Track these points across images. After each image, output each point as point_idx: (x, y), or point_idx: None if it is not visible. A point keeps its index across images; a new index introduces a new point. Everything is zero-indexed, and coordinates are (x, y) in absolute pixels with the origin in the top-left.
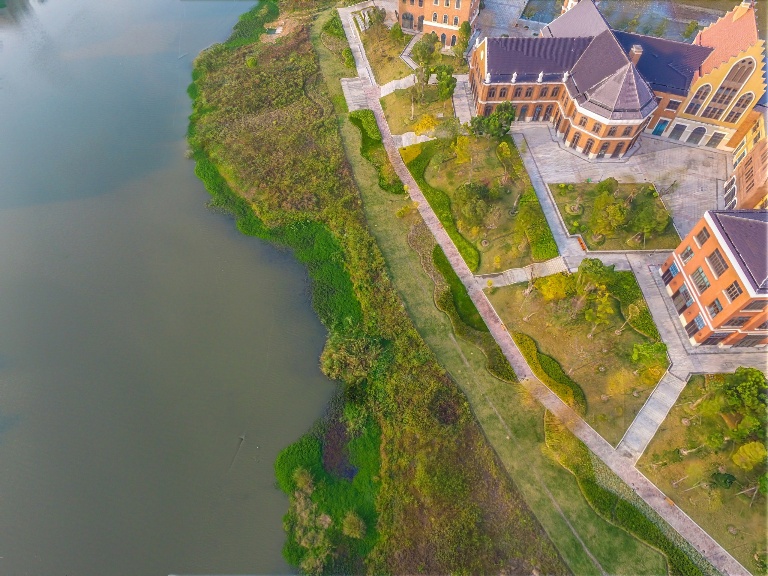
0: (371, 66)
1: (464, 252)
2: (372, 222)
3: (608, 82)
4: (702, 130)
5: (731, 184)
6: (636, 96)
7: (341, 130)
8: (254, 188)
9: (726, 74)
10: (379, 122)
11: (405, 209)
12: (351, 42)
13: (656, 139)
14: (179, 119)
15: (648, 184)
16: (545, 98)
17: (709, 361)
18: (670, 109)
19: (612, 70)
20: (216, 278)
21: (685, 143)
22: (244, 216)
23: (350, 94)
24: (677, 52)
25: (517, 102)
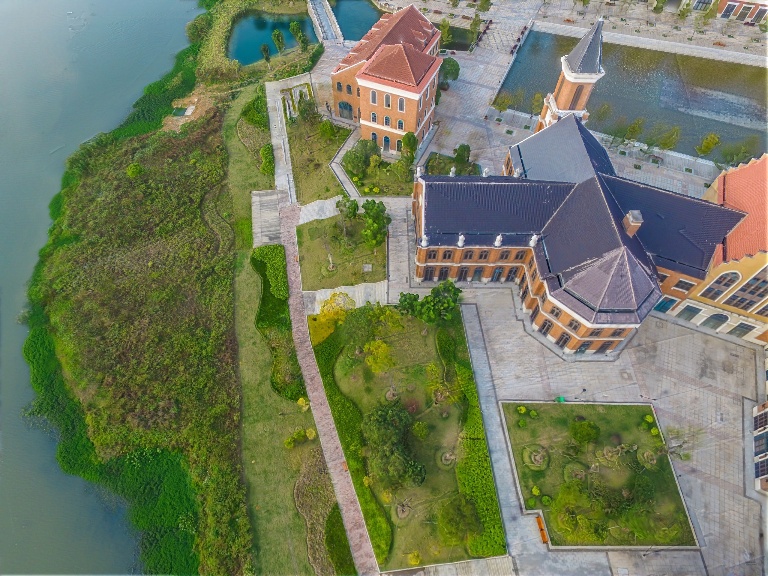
0: (294, 173)
1: (371, 524)
2: (249, 455)
3: (591, 269)
4: (723, 317)
5: (764, 420)
6: (631, 292)
7: (236, 280)
8: (95, 385)
9: (763, 266)
10: (290, 267)
11: (297, 436)
12: (274, 134)
13: (659, 318)
14: (26, 253)
15: (645, 407)
16: (507, 260)
17: None
18: (679, 288)
19: (597, 250)
20: (2, 561)
21: (698, 327)
22: (70, 437)
23: (260, 217)
24: (692, 214)
25: (468, 264)
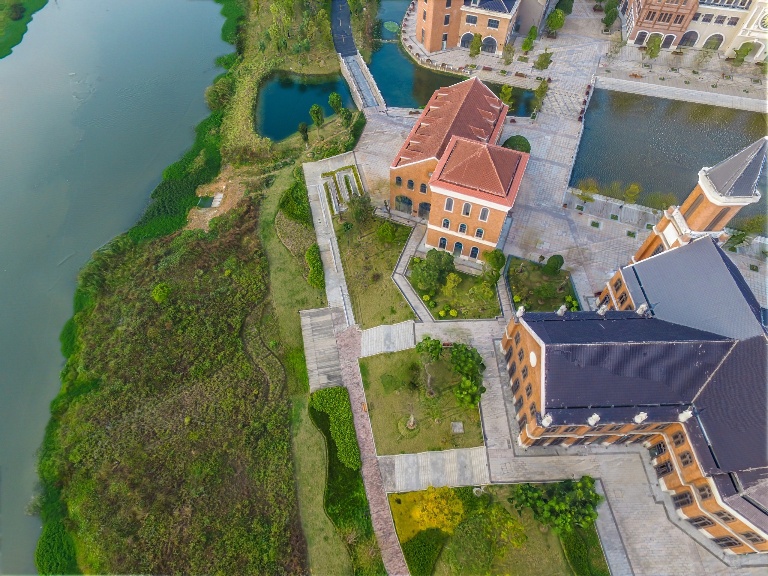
0: (348, 285)
1: None
2: None
3: None
4: None
5: None
6: None
7: (294, 441)
8: None
9: None
10: (357, 419)
11: None
12: (319, 232)
13: None
14: (35, 408)
15: None
16: (642, 430)
17: None
18: None
19: None
20: None
21: None
22: None
23: (313, 347)
24: None
25: (593, 435)
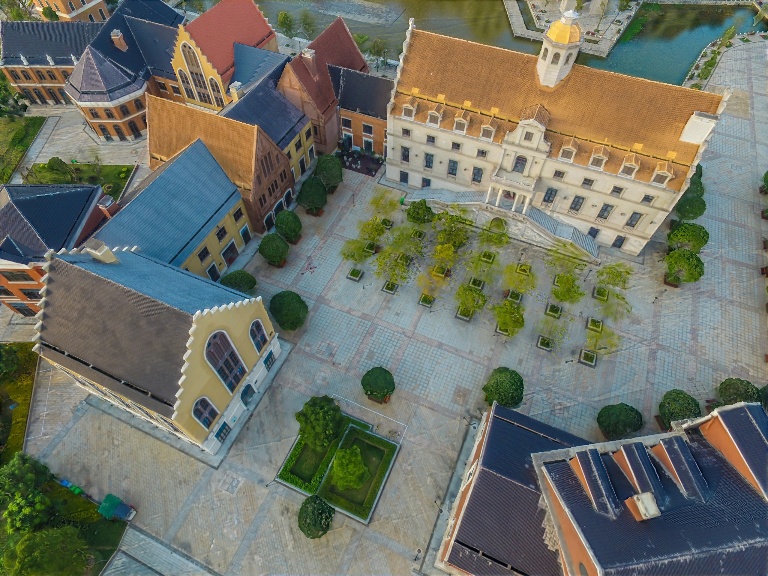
0: None
1: None
2: None
3: (77, 65)
4: None
5: None
6: (100, 79)
7: None
8: None
9: (183, 59)
10: None
11: None
12: None
13: None
14: None
15: (130, 166)
16: None
17: (22, 331)
18: (177, 94)
19: None
20: None
21: None
22: None
23: None
24: (173, 38)
25: (48, 85)
